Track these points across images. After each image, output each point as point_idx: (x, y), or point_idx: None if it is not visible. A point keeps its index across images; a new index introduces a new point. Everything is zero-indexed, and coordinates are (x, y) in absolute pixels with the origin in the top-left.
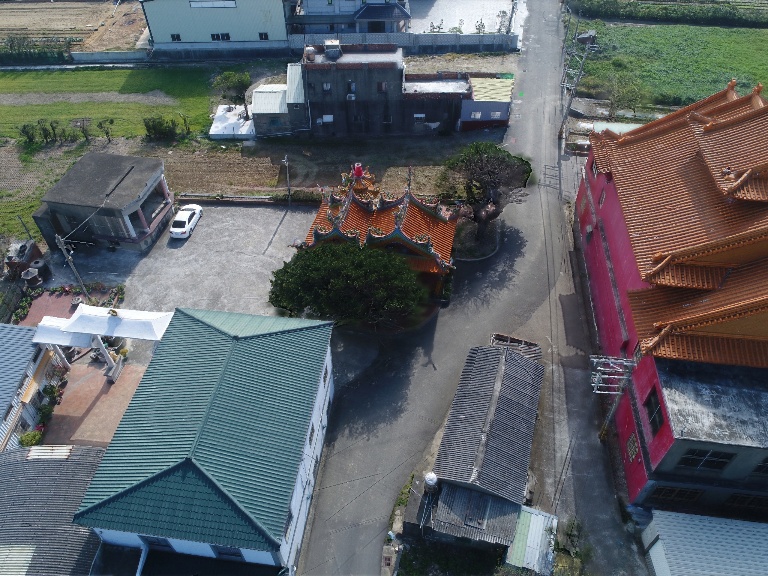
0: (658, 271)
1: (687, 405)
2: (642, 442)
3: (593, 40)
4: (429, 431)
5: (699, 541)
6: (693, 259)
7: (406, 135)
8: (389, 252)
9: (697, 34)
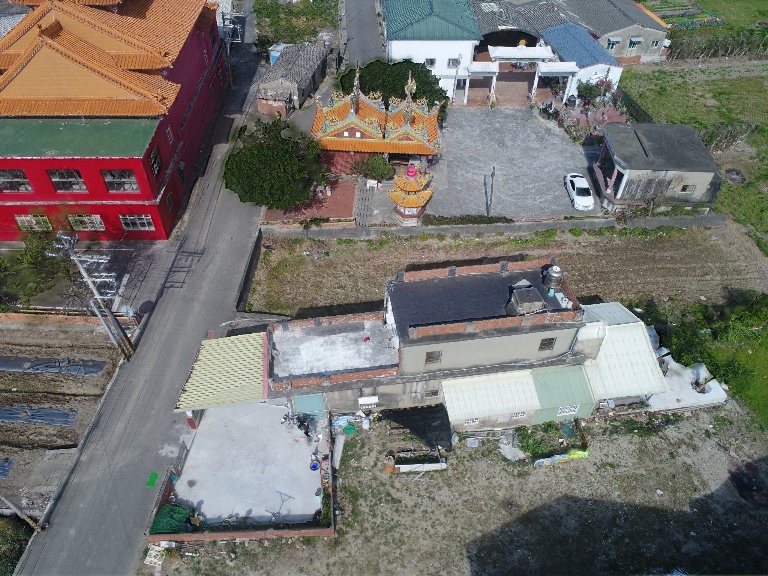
0: None
1: None
2: (220, 50)
3: None
4: (329, 91)
5: None
6: None
7: None
8: (362, 88)
9: None
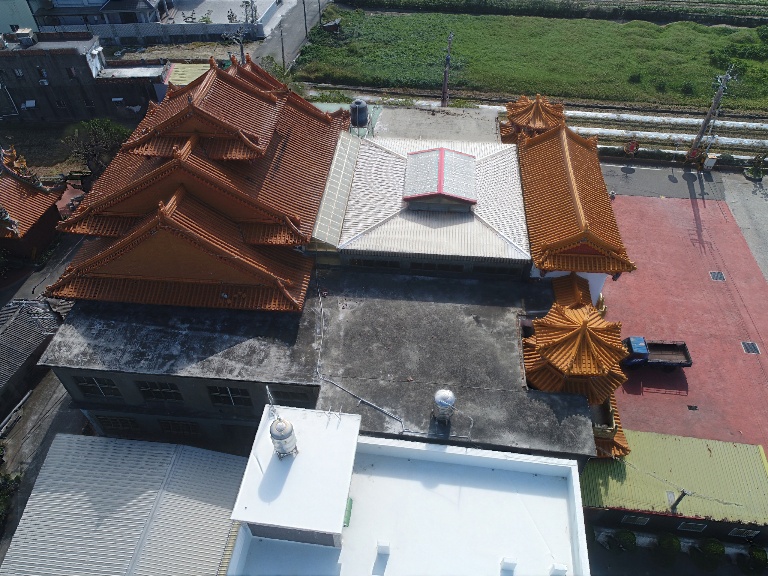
0: (75, 221)
1: (71, 338)
2: None
3: (337, 28)
4: None
5: (77, 457)
6: (105, 210)
7: (113, 119)
8: None
9: (443, 21)
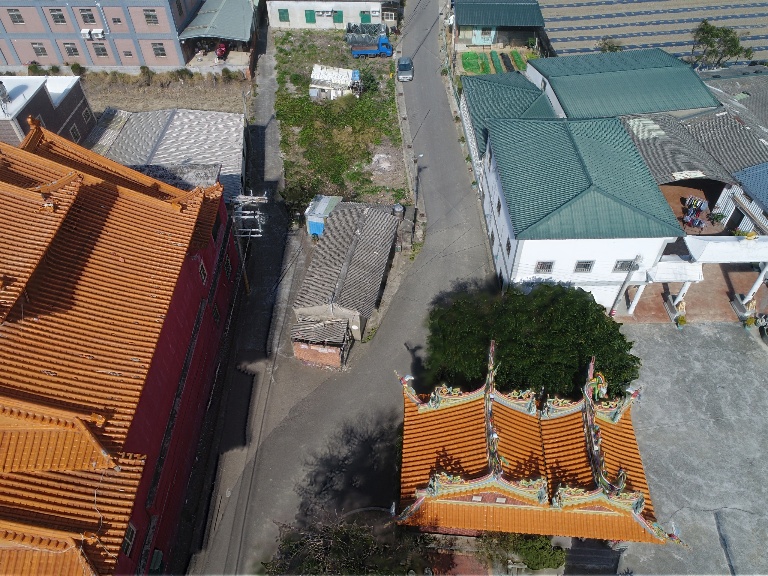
0: None
1: (199, 182)
2: (227, 235)
3: None
4: (404, 290)
5: None
6: None
7: None
8: None
9: None
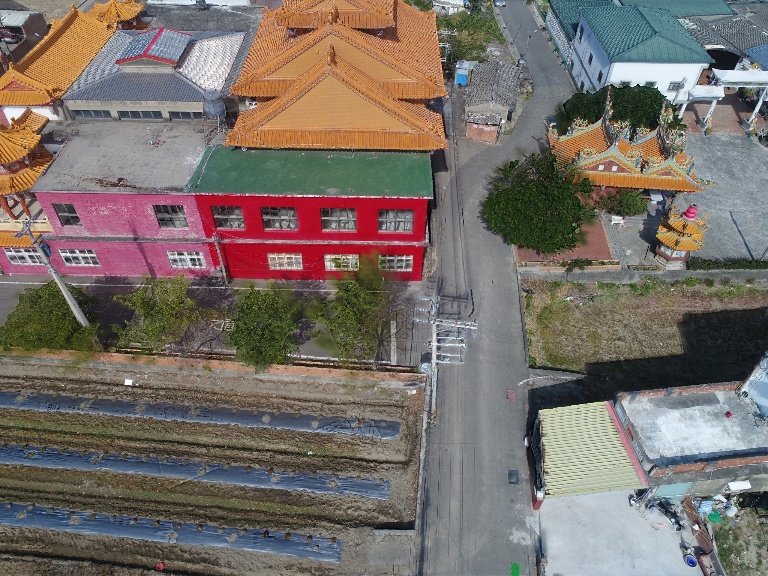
0: None
1: None
2: None
3: None
4: (526, 113)
5: None
6: None
7: None
8: None
9: None
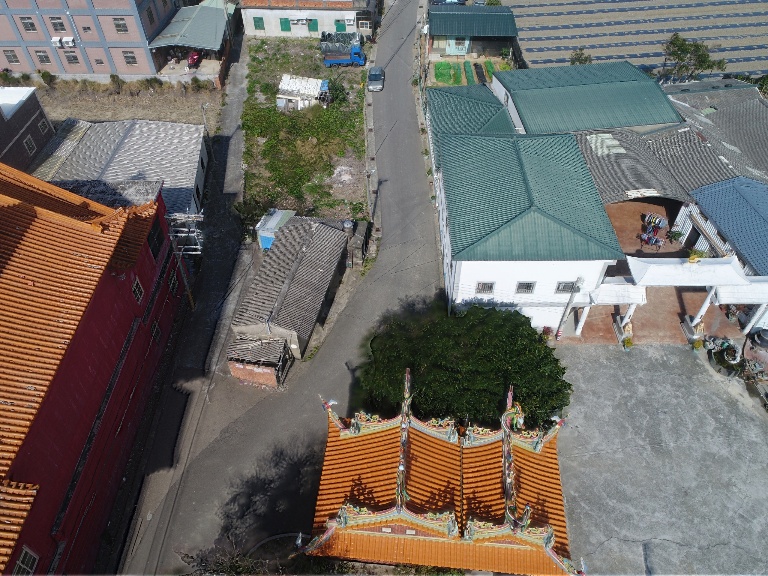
0: None
1: (139, 199)
2: (171, 251)
3: None
4: (351, 307)
5: None
6: None
7: None
8: None
9: None
